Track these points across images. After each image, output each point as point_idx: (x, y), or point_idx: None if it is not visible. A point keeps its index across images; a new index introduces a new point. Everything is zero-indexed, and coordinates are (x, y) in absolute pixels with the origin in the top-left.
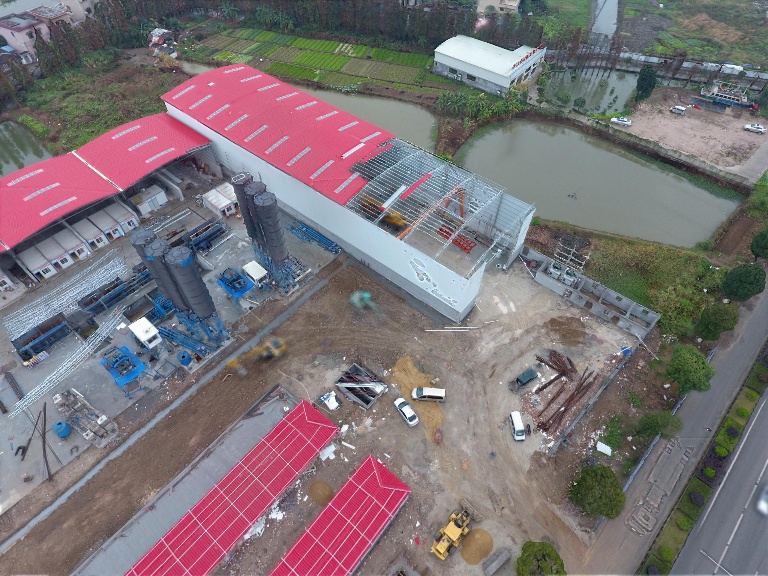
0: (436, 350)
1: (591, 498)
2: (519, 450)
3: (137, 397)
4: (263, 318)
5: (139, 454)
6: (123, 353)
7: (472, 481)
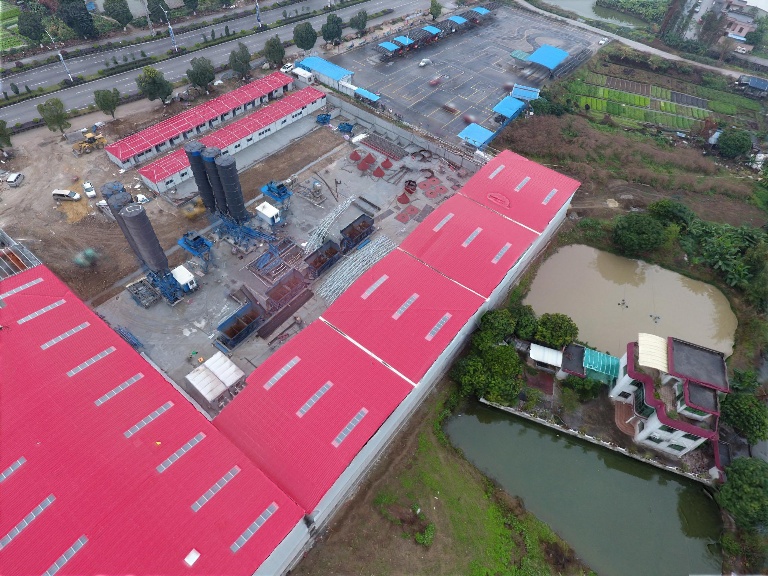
0: (42, 225)
1: (0, 122)
2: (26, 174)
3: (278, 203)
4: (185, 251)
5: (269, 180)
6: (272, 186)
7: (68, 164)
